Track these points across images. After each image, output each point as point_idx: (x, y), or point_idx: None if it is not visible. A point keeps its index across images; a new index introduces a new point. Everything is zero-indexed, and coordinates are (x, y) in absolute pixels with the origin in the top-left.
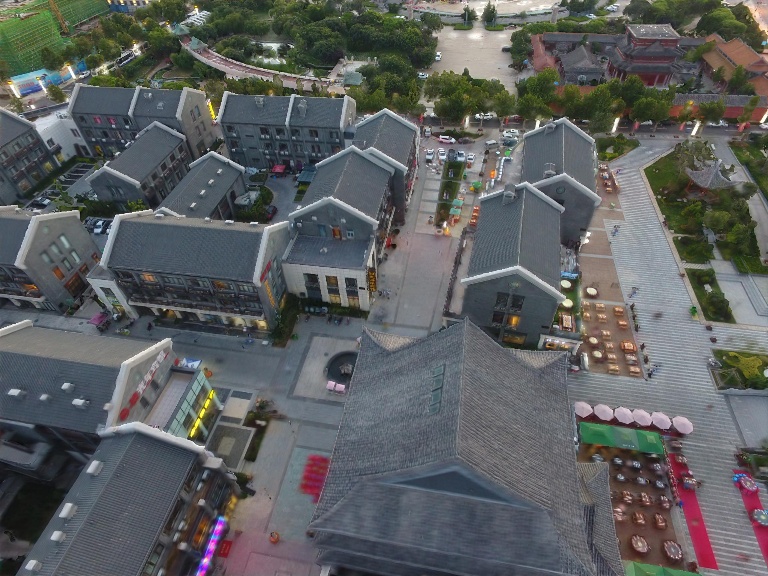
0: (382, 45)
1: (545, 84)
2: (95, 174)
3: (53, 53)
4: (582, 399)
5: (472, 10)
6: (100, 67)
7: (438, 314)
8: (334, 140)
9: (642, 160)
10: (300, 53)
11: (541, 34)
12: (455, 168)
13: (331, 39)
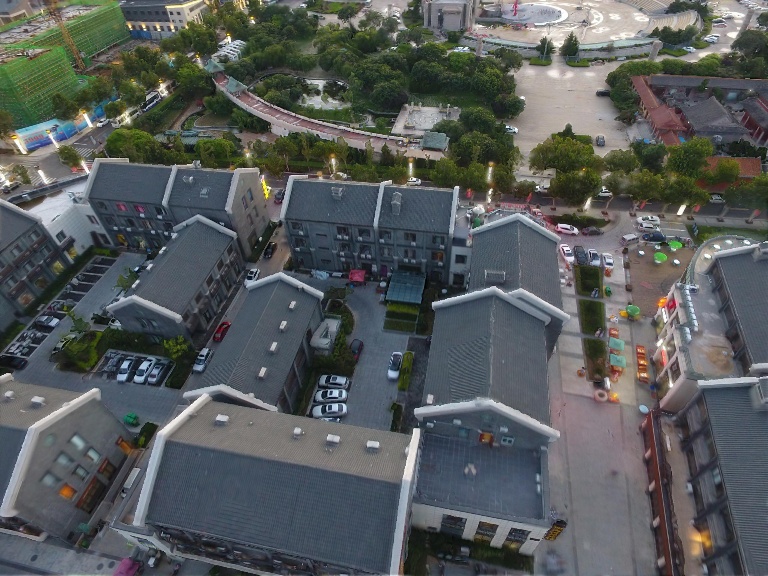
0: (455, 88)
1: (694, 158)
2: (120, 304)
3: (66, 100)
4: None
5: (549, 41)
6: (121, 115)
7: (642, 567)
8: (437, 246)
9: None
10: (354, 94)
11: (645, 75)
12: (591, 278)
13: (394, 81)
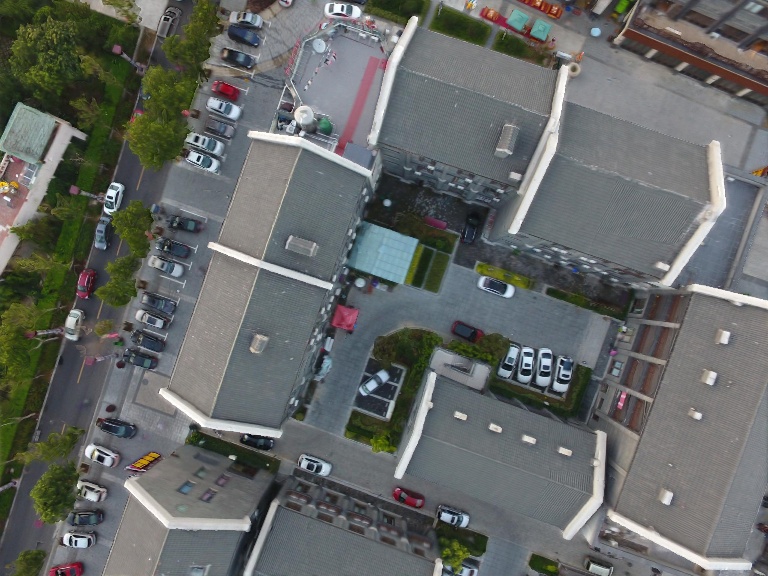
0: None
1: None
2: None
3: None
4: None
5: None
6: None
7: (732, 110)
8: None
9: None
10: None
11: None
12: None
13: None
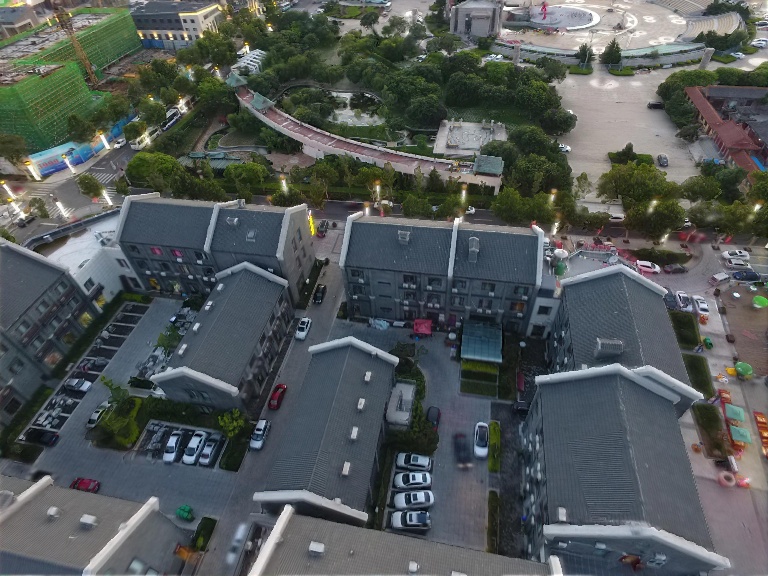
0: (497, 102)
1: None
2: (167, 376)
3: (83, 121)
4: None
5: (588, 48)
6: (141, 136)
7: None
8: (519, 297)
9: None
10: None
11: (700, 86)
12: (686, 327)
13: (433, 95)
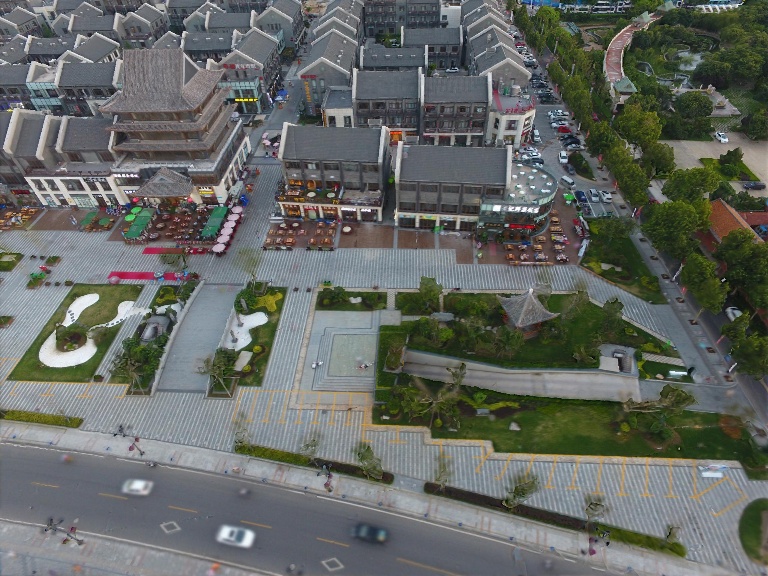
0: None
1: None
2: None
3: None
4: (251, 219)
5: None
6: (571, 5)
7: None
8: None
9: (604, 297)
10: None
11: None
12: None
13: (725, 63)
